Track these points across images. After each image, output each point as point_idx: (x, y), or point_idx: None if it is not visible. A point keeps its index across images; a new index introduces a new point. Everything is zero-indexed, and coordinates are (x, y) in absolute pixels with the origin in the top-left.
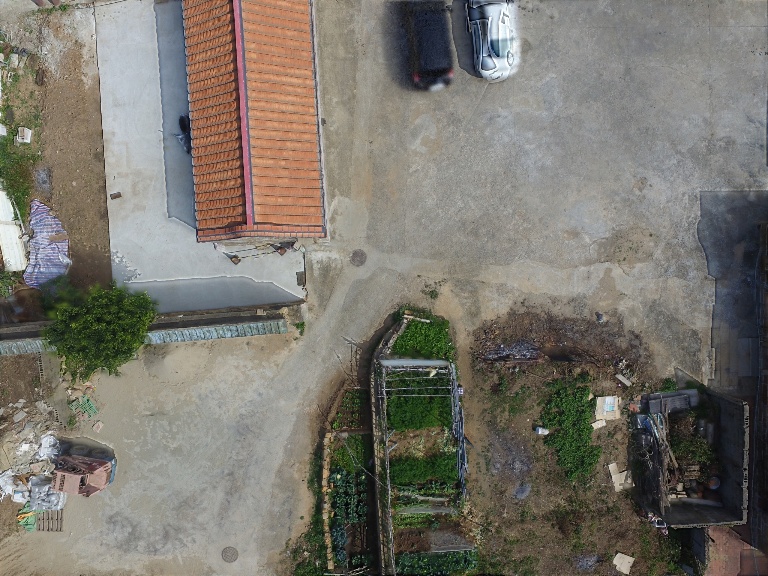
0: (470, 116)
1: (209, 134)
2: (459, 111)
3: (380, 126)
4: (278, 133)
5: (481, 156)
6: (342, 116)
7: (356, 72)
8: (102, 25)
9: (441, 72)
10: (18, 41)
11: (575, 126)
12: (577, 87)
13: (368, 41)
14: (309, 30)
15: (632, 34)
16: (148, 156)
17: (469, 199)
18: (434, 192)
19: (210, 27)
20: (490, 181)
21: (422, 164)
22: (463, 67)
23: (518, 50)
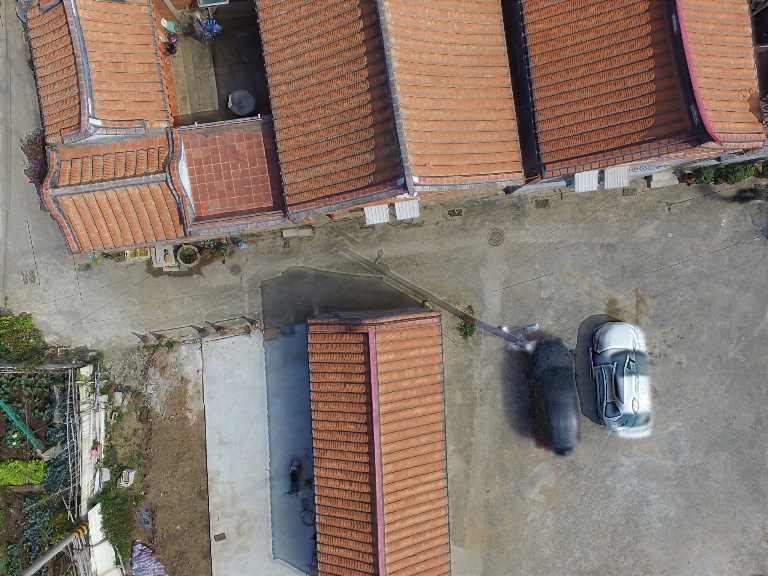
0: (592, 464)
1: (338, 545)
2: (580, 459)
3: (498, 474)
4: (412, 549)
5: (602, 505)
6: (458, 464)
7: (474, 419)
8: (209, 361)
9: (562, 419)
10: (123, 379)
11: (702, 476)
12: (705, 436)
13: (487, 386)
14: (442, 428)
15: (764, 382)
16: (254, 496)
17: (588, 549)
18: (552, 541)
19: (343, 439)
20: (611, 531)
21: (540, 513)
22: (586, 414)
23: (644, 397)
